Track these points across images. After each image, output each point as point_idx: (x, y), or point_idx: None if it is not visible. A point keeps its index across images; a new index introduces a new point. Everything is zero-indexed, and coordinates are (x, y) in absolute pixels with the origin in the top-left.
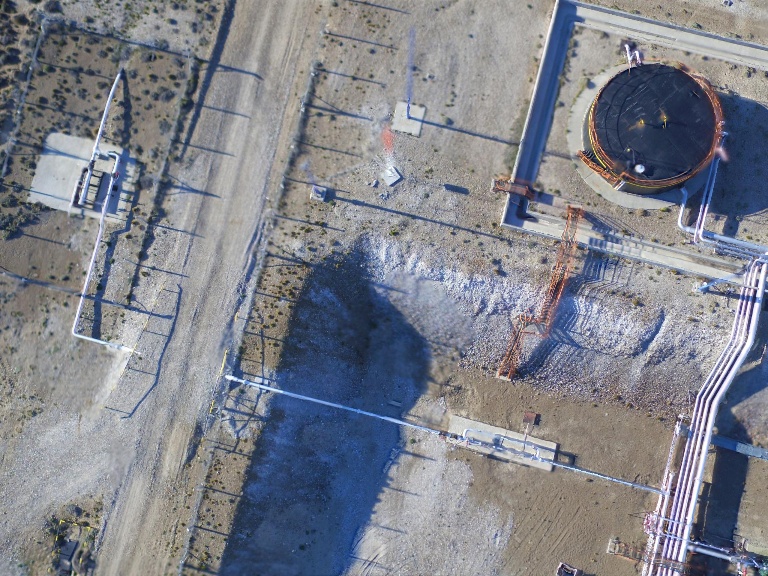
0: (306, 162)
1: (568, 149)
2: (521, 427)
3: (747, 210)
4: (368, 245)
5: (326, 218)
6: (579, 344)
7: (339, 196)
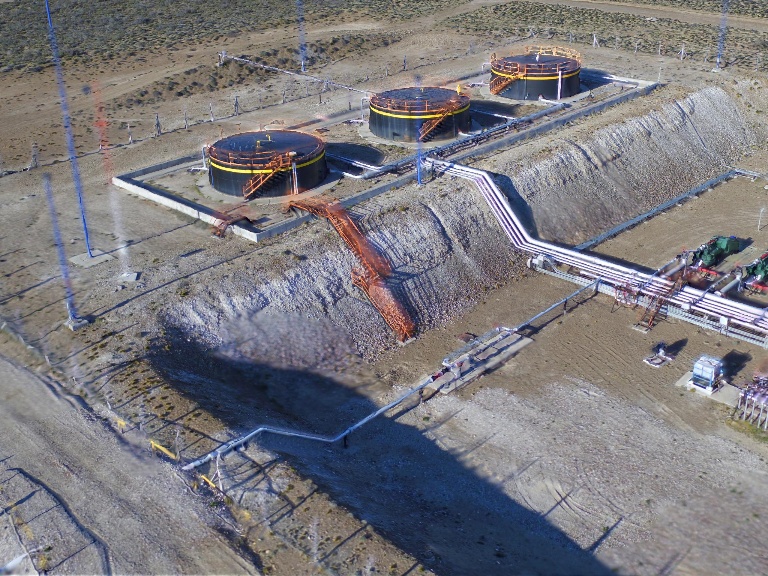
0: (33, 325)
1: (235, 205)
2: (471, 346)
3: (378, 162)
4: (174, 319)
5: (108, 330)
6: (414, 273)
7: (99, 314)
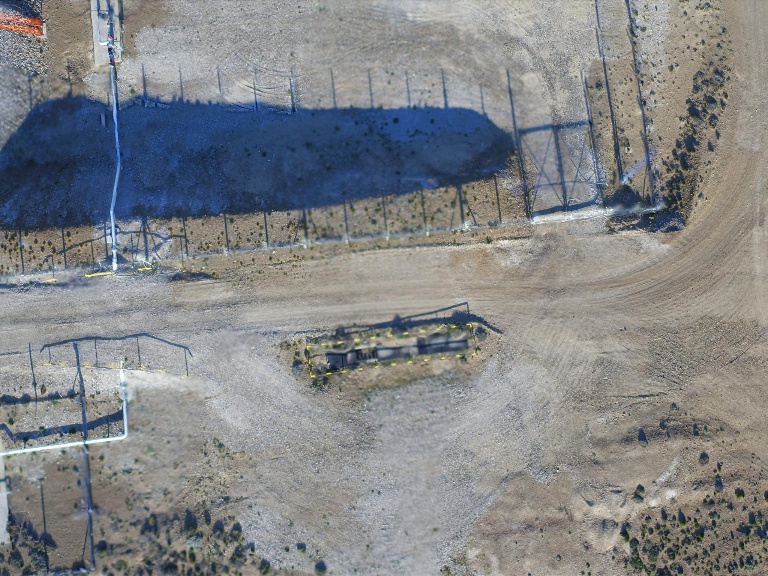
0: None
1: None
2: (85, 0)
3: None
4: None
5: None
6: None
7: None
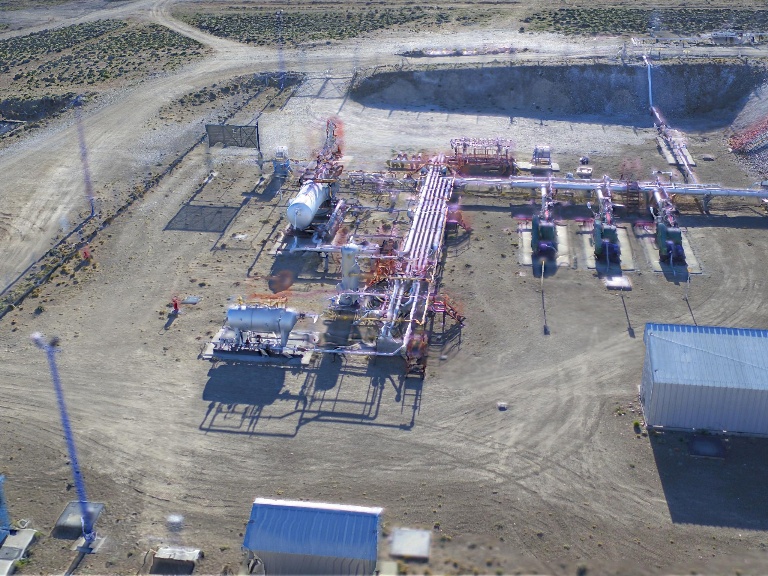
0: None
1: None
2: None
3: None
4: None
5: None
6: None
7: None
